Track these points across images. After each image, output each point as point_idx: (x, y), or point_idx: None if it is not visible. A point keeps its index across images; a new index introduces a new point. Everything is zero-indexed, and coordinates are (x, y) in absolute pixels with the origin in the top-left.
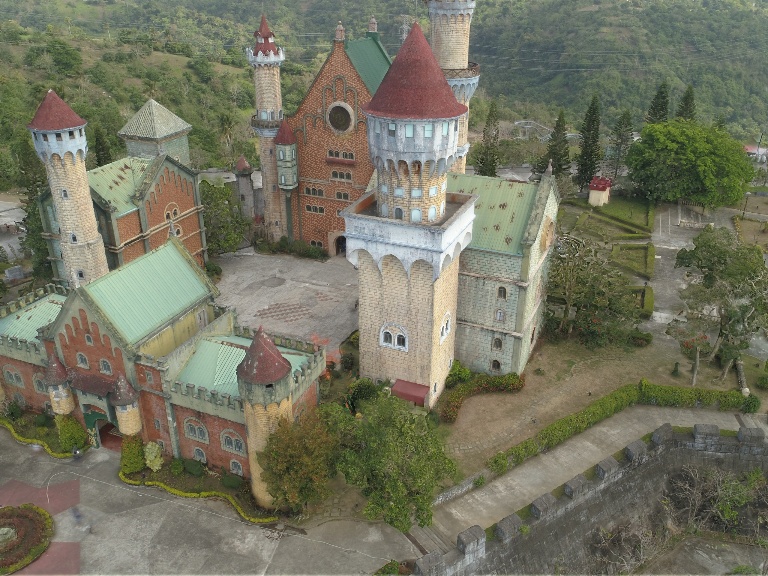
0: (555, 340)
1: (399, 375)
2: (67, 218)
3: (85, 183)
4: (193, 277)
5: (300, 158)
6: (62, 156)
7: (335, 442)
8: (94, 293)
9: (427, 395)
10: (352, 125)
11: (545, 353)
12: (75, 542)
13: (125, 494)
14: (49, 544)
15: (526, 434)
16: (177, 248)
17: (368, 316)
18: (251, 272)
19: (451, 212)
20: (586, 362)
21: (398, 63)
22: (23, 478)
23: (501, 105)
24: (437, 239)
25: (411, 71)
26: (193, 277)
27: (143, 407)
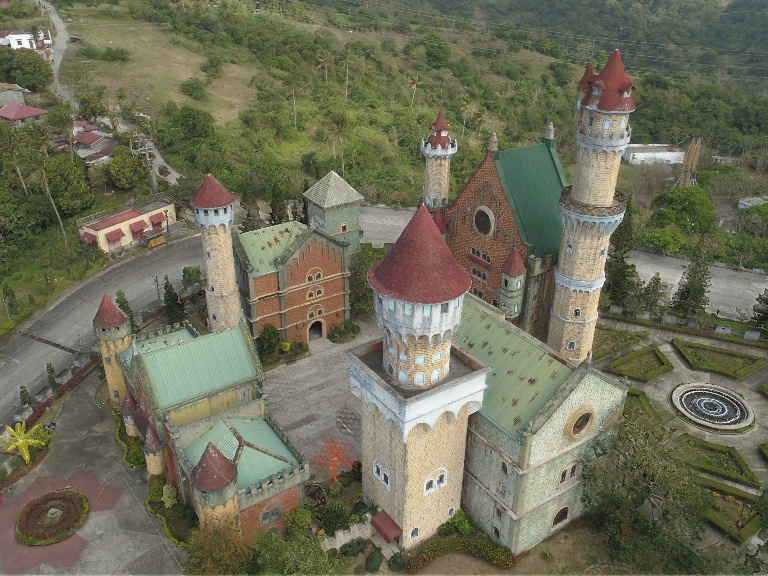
0: (596, 527)
1: (385, 507)
2: (209, 273)
3: (226, 249)
4: (247, 360)
5: (450, 246)
6: (207, 227)
7: (245, 558)
8: (150, 360)
9: (401, 537)
10: (492, 231)
11: (574, 537)
12: (87, 540)
13: (141, 516)
14: (73, 534)
15: None
16: (242, 332)
17: (367, 444)
18: None
19: (452, 379)
20: (610, 567)
21: (400, 238)
22: (99, 471)
23: (722, 222)
24: (402, 409)
25: (405, 250)
26: (247, 360)
27: (170, 456)
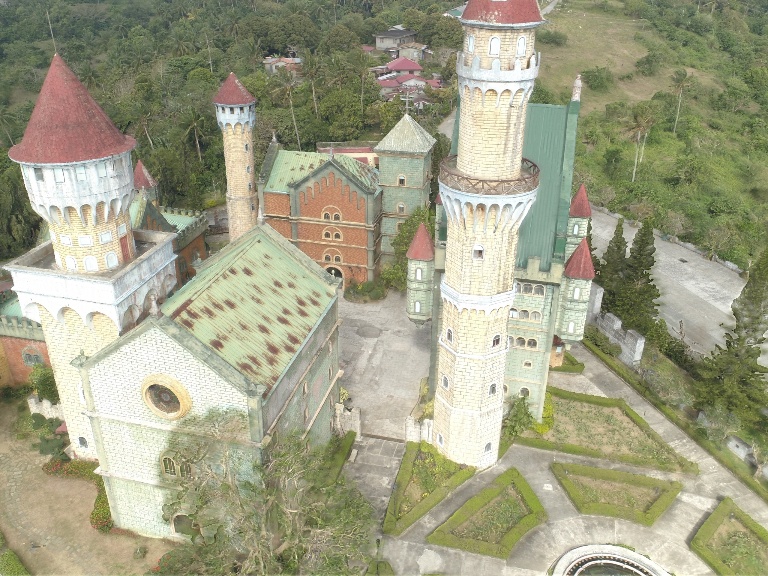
0: None
1: None
2: None
3: (236, 151)
4: None
5: None
6: (219, 124)
7: None
8: None
9: None
10: None
11: None
12: None
13: None
14: None
15: (19, 540)
16: None
17: None
18: (390, 315)
19: None
20: None
21: None
22: None
23: None
24: None
25: None
26: None
27: None
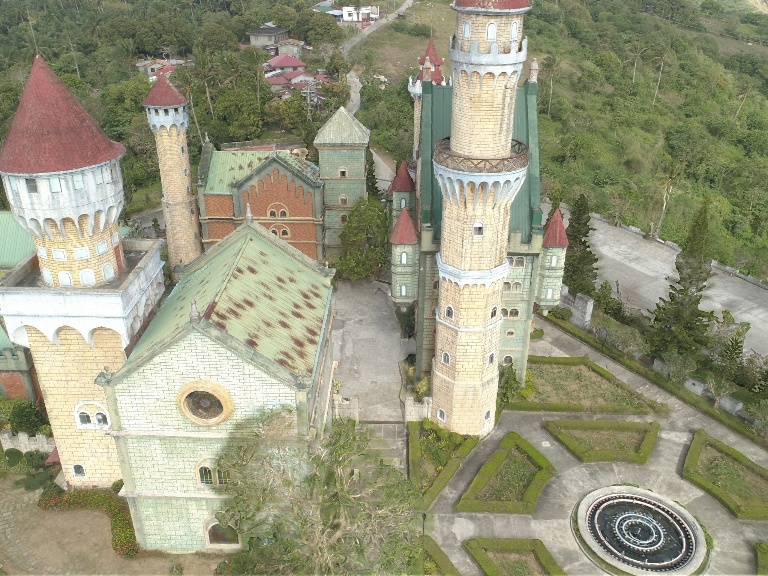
0: None
1: None
2: None
3: (172, 154)
4: None
5: None
6: (152, 127)
7: None
8: None
9: None
10: None
11: None
12: None
13: None
14: None
15: None
16: None
17: None
18: (348, 306)
19: None
20: None
21: None
22: None
23: None
24: None
25: None
26: None
27: None
